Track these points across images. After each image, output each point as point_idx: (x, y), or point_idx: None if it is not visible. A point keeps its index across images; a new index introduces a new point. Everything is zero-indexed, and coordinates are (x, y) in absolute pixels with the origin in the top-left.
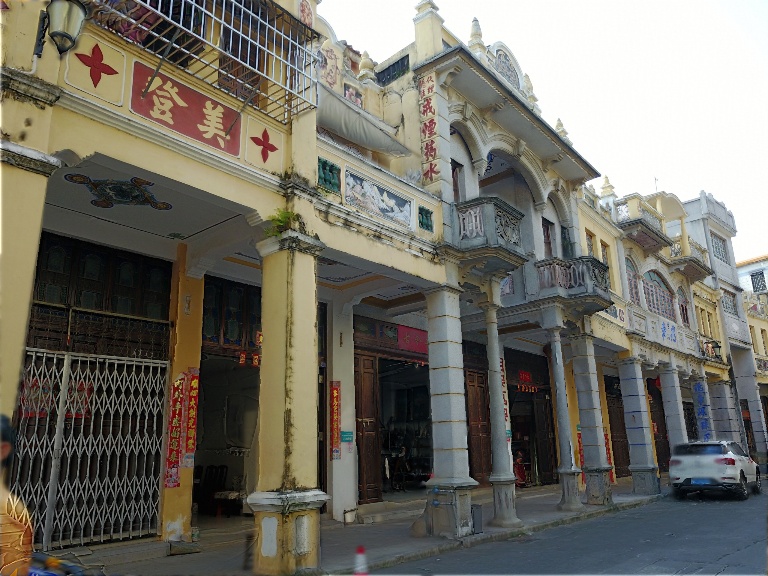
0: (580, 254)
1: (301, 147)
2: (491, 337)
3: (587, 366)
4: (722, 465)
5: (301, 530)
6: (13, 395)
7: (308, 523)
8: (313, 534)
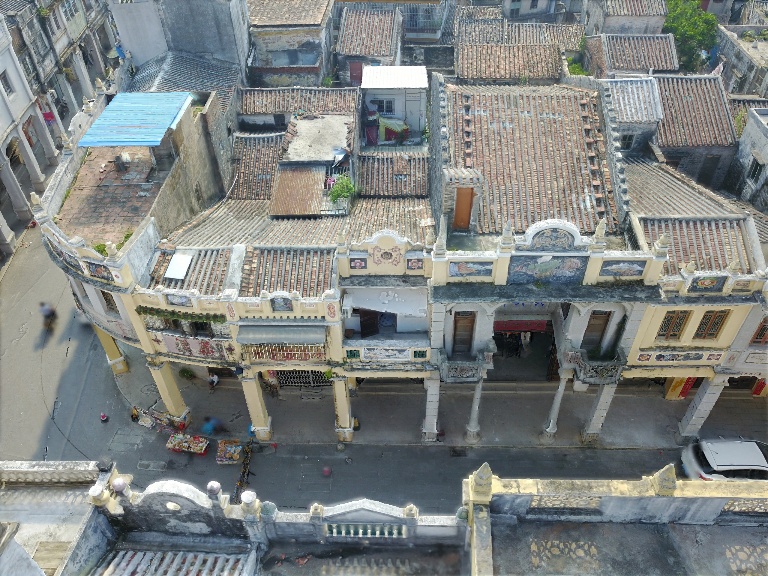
0: (632, 335)
1: (334, 353)
2: (476, 386)
3: (602, 391)
4: (697, 476)
5: (345, 434)
6: (262, 413)
7: (347, 433)
8: (349, 435)
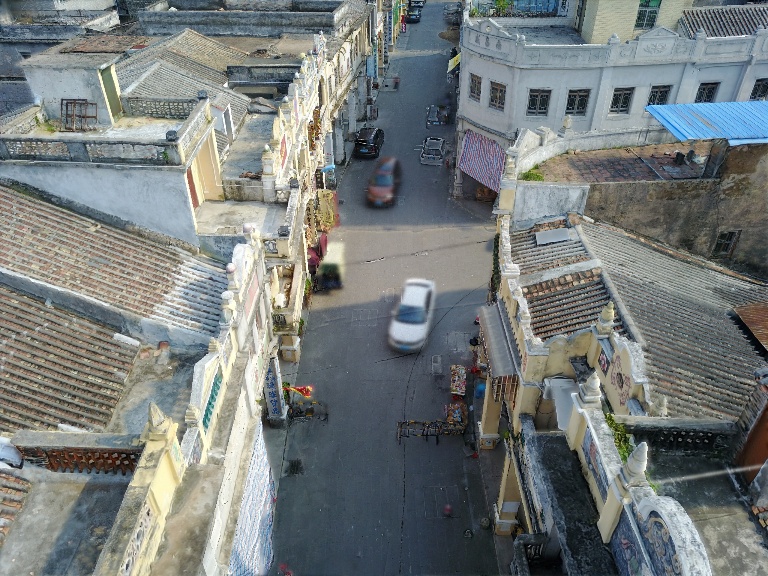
0: None
1: None
2: None
3: None
4: None
5: None
6: None
7: None
8: None
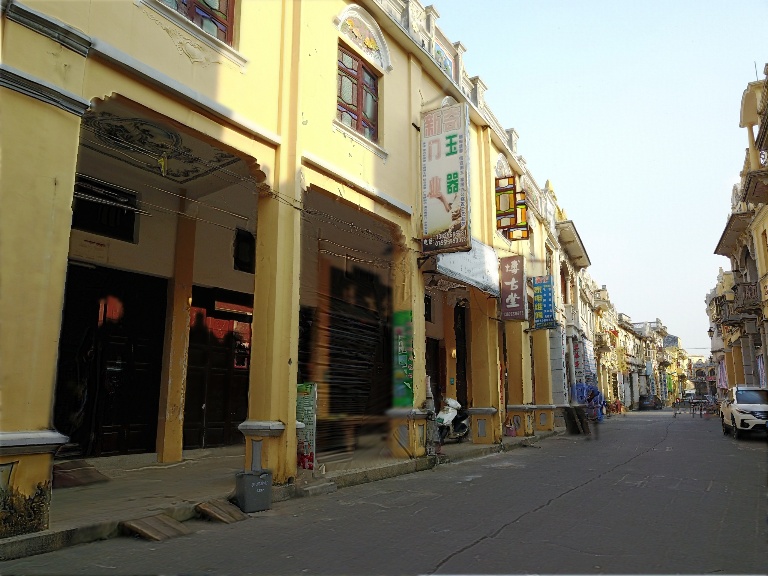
0: None
1: None
2: None
3: None
4: None
5: None
6: None
7: None
8: None
